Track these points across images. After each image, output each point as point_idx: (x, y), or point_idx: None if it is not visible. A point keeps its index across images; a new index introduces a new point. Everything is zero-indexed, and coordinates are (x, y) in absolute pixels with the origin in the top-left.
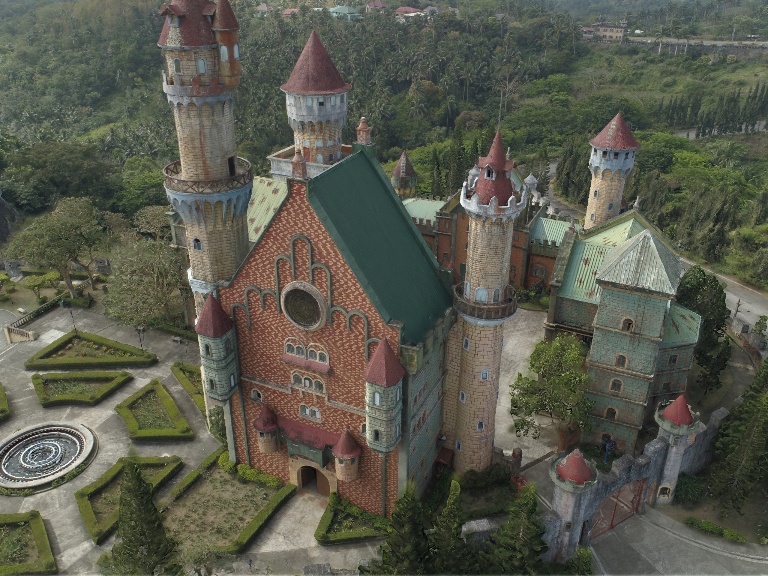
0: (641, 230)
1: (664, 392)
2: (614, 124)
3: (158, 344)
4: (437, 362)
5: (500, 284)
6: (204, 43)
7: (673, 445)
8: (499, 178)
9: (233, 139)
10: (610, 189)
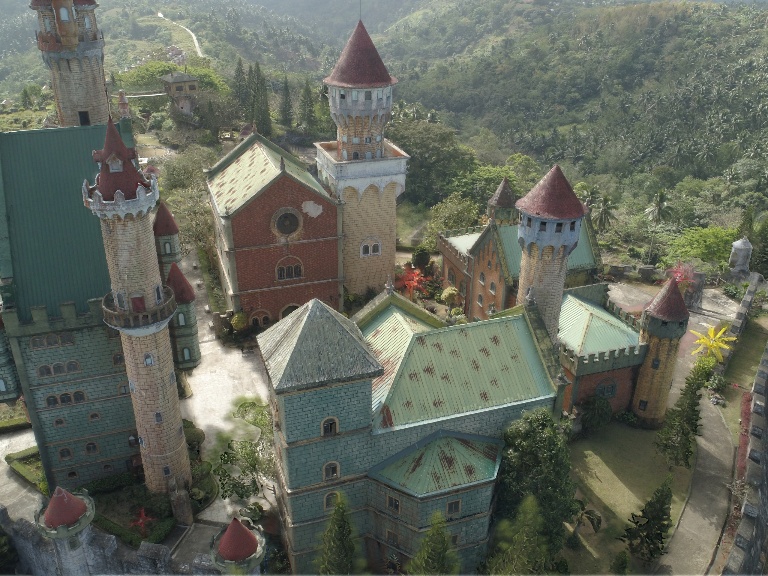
0: (514, 332)
1: (391, 543)
2: (544, 178)
3: None
4: (106, 351)
5: (123, 289)
6: (43, 4)
7: (222, 575)
8: (103, 169)
9: (89, 96)
10: (529, 267)
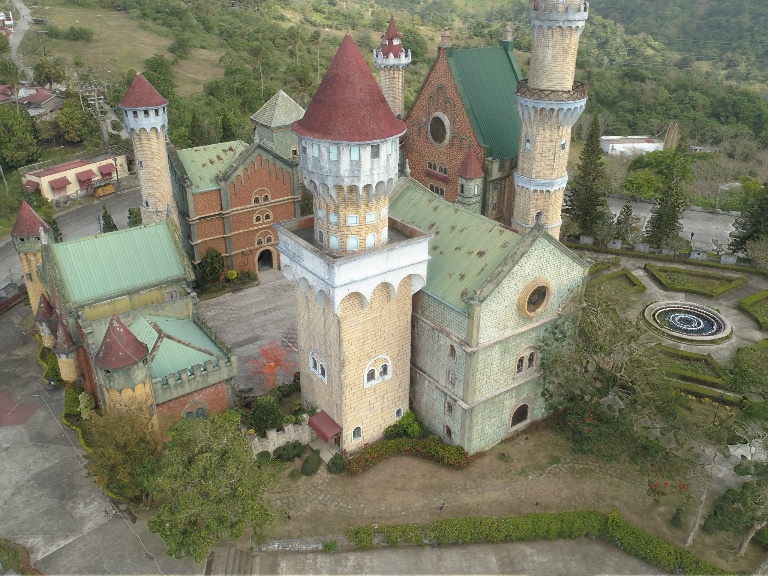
0: None
1: None
2: None
3: (602, 399)
4: None
5: None
6: None
7: None
8: None
9: None
10: None
